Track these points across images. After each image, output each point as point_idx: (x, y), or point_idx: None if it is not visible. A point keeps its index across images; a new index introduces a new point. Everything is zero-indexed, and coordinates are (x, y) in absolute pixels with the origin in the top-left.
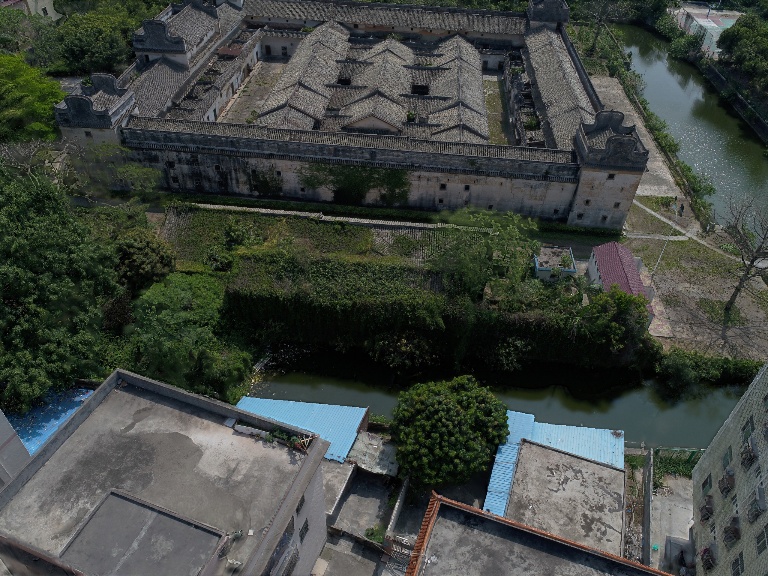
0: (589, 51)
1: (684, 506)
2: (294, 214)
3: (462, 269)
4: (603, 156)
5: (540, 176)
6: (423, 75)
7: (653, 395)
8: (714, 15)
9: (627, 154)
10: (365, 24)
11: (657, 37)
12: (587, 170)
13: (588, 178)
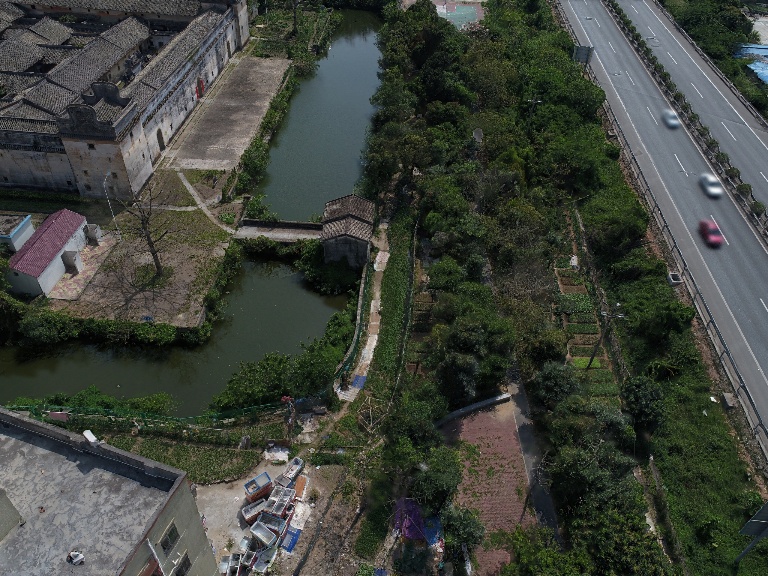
0: (291, 34)
1: None
2: None
3: None
4: (71, 125)
5: (32, 146)
6: (56, 54)
7: (9, 354)
8: (454, 2)
9: (92, 123)
10: (40, 5)
11: (382, 22)
12: (65, 140)
13: (71, 148)
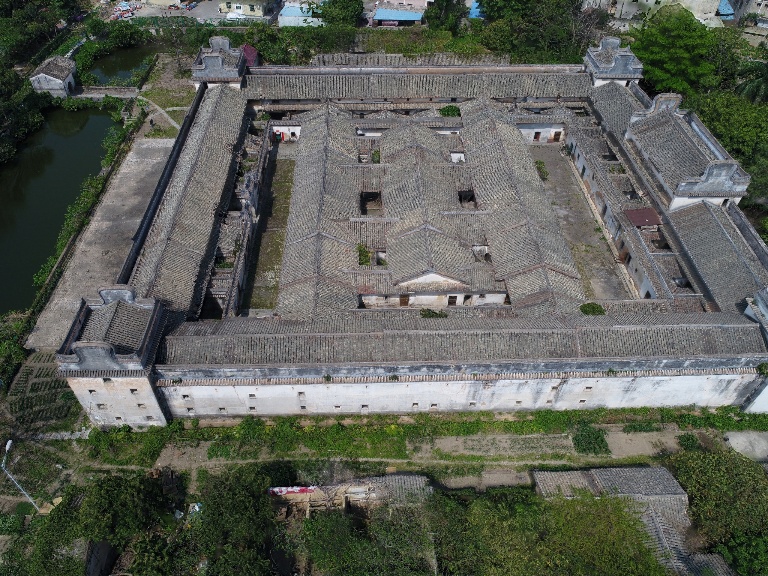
0: None
1: None
2: None
3: (336, 31)
4: None
5: None
6: None
7: None
8: None
9: None
10: None
11: None
12: None
13: None
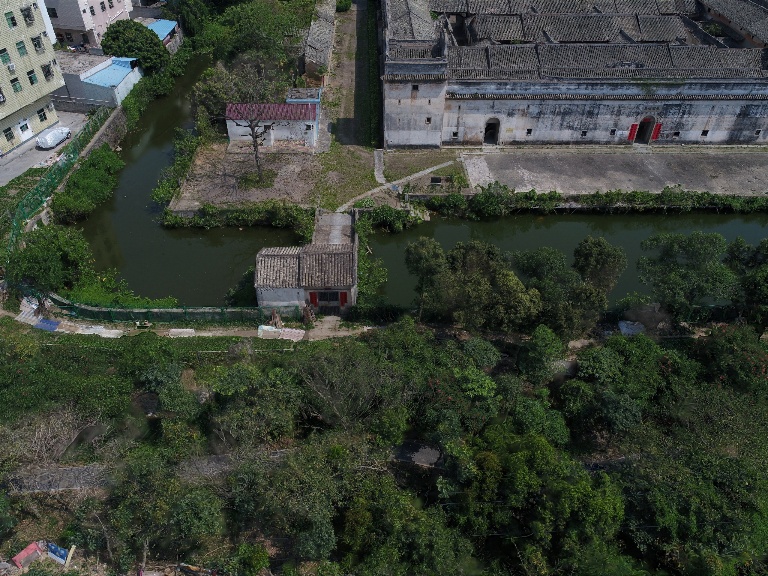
0: None
1: (74, 123)
2: (315, 7)
3: (249, 37)
4: None
5: None
6: None
7: None
8: None
9: None
10: None
11: None
12: None
13: None
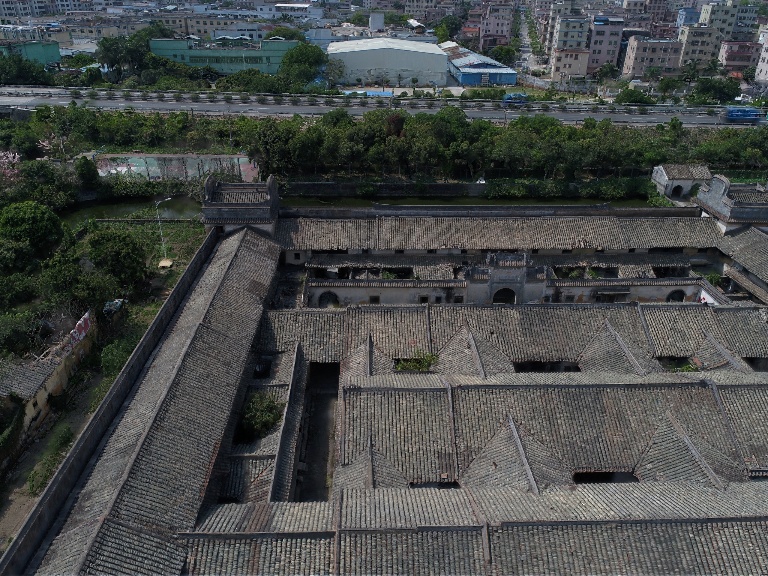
0: None
1: None
2: None
3: None
4: None
5: None
6: (491, 359)
7: None
8: None
9: None
10: None
11: (141, 202)
12: None
13: None
